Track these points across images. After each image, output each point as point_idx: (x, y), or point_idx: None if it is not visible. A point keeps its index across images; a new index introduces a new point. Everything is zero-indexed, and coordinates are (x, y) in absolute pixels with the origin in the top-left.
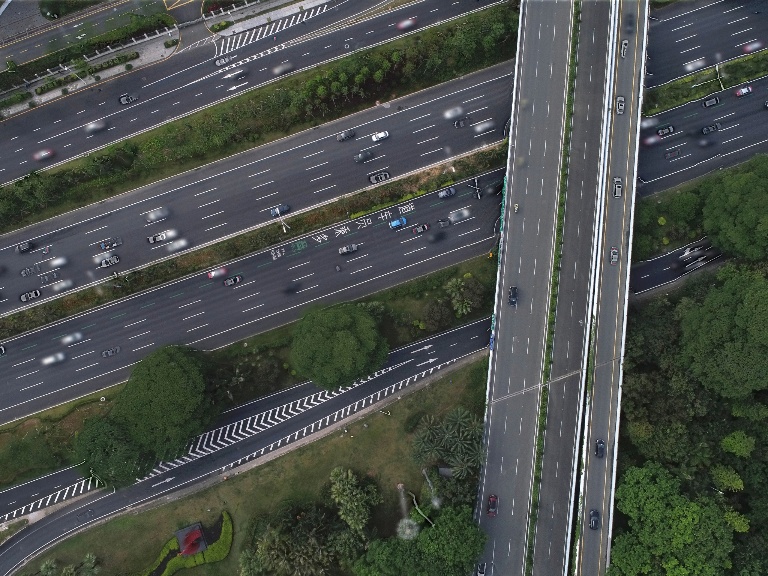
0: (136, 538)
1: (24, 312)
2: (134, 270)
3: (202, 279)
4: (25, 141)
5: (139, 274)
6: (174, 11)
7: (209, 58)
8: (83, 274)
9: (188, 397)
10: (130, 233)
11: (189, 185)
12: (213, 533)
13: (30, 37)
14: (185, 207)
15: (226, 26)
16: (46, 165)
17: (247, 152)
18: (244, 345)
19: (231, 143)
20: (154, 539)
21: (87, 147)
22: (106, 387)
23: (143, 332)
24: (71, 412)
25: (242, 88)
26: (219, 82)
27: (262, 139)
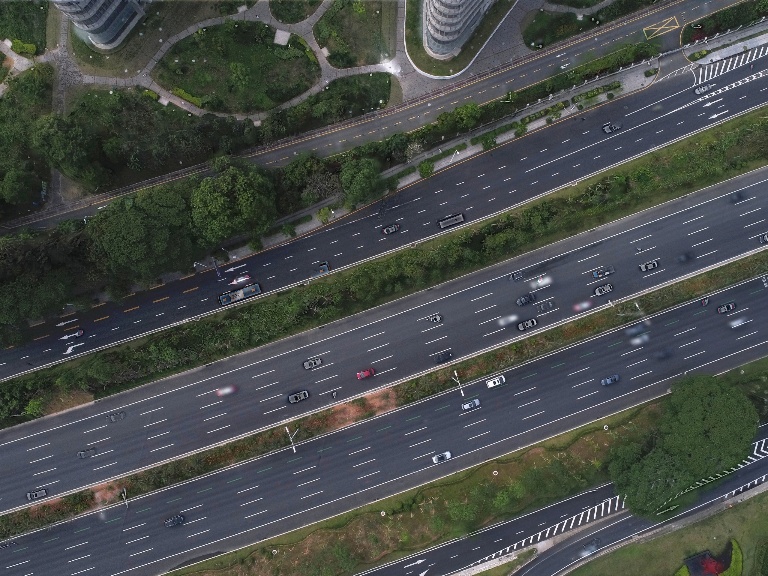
0: (644, 567)
1: (524, 341)
2: (629, 298)
3: (696, 307)
4: (513, 170)
5: (649, 303)
6: (654, 40)
7: (688, 87)
8: (578, 302)
9: (745, 427)
10: (622, 261)
11: (677, 213)
12: (723, 561)
13: (515, 67)
14: (675, 235)
15: (705, 55)
16: (535, 194)
17: (732, 180)
18: (741, 372)
19: (719, 171)
20: (663, 568)
21: (574, 176)
22: (607, 415)
23: (640, 360)
24: (575, 441)
25: (723, 116)
26: (700, 110)
27: (747, 167)
